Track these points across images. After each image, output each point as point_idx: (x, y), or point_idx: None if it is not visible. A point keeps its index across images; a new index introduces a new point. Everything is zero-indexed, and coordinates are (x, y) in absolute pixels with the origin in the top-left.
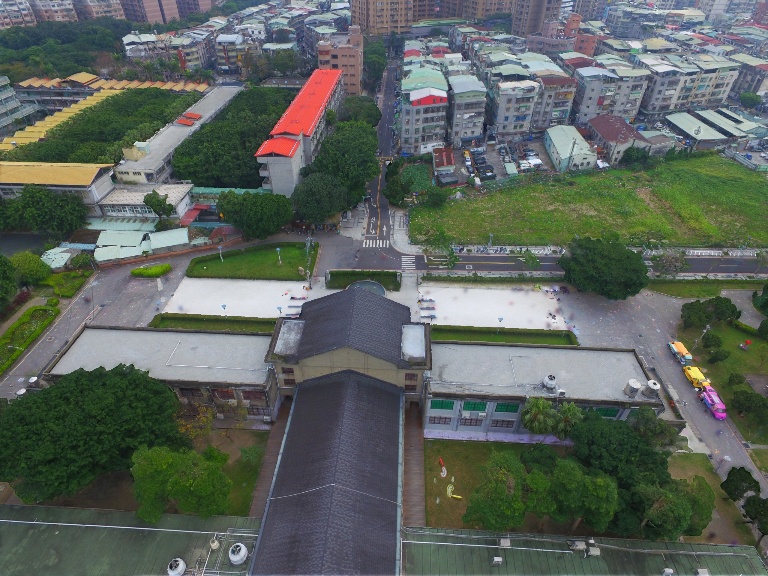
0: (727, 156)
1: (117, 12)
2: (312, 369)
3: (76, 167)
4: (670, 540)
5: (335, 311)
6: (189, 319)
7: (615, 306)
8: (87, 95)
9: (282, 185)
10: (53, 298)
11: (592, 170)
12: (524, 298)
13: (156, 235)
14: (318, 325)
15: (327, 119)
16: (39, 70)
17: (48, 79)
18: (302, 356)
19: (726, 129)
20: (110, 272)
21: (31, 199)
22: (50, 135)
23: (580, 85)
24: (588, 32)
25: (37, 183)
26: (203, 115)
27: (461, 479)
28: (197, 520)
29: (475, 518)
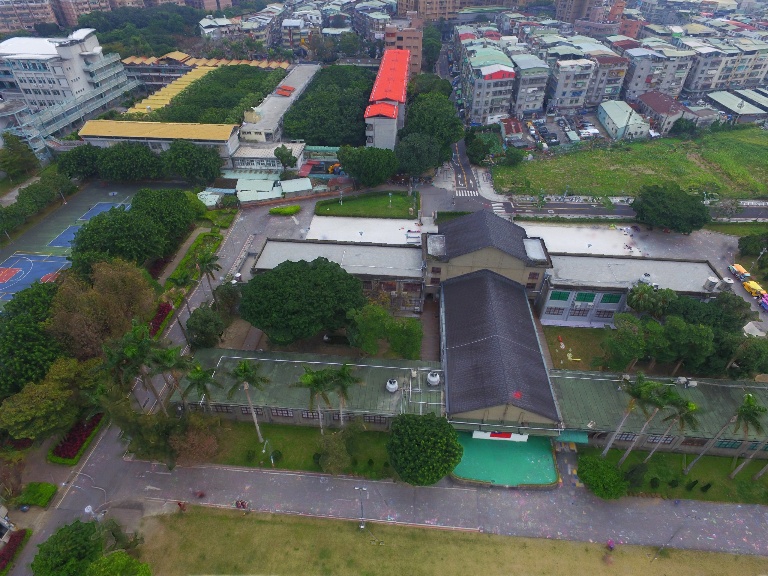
0: (767, 128)
1: None
2: (456, 269)
3: (214, 125)
4: (747, 380)
5: (471, 226)
6: None
7: (680, 241)
8: (182, 71)
9: (384, 144)
10: (215, 227)
11: (645, 138)
12: (602, 234)
13: (286, 182)
14: (459, 236)
15: (408, 91)
16: (138, 49)
17: (145, 57)
18: (453, 256)
19: (765, 105)
20: (251, 211)
21: (181, 151)
22: (175, 102)
23: (630, 64)
24: (631, 17)
25: (184, 138)
26: (295, 88)
27: (577, 350)
28: (394, 362)
29: (601, 363)
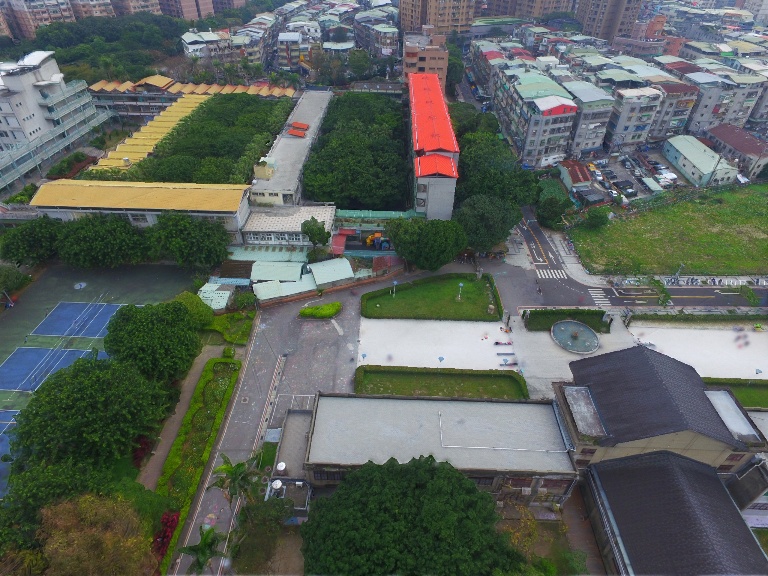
0: None
1: (154, 7)
2: (619, 450)
3: (217, 190)
4: None
5: (632, 378)
6: (395, 372)
7: None
8: (165, 100)
9: (439, 208)
10: (229, 348)
11: (735, 186)
12: (750, 340)
13: (318, 268)
14: (618, 396)
15: None
16: (109, 72)
17: (118, 82)
18: (623, 439)
19: None
20: (274, 312)
21: (174, 228)
22: (160, 149)
23: None
24: (670, 34)
25: (178, 209)
26: (309, 124)
27: None
28: None
29: None
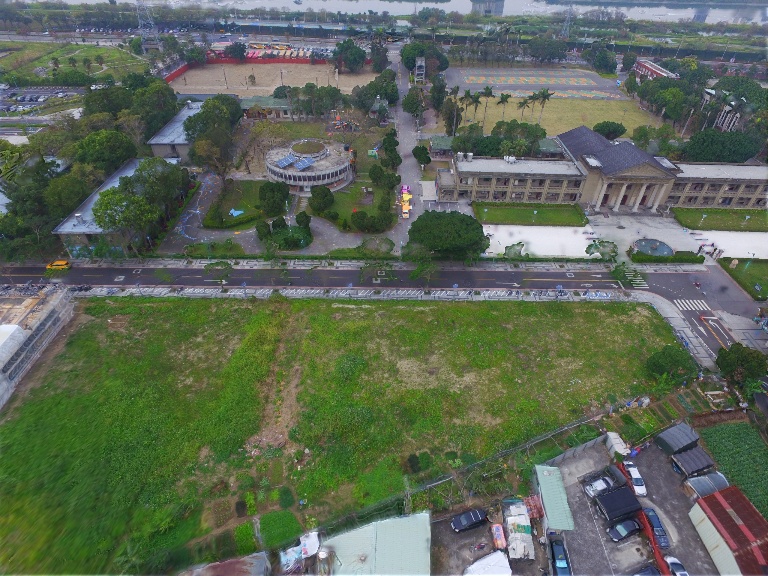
0: None
1: None
2: None
3: None
4: None
5: None
6: None
7: None
8: None
9: None
10: None
11: (344, 518)
12: None
13: None
14: None
15: None
16: None
17: None
18: None
19: None
20: None
21: None
22: None
23: None
24: None
25: None
26: None
27: None
28: None
29: None
